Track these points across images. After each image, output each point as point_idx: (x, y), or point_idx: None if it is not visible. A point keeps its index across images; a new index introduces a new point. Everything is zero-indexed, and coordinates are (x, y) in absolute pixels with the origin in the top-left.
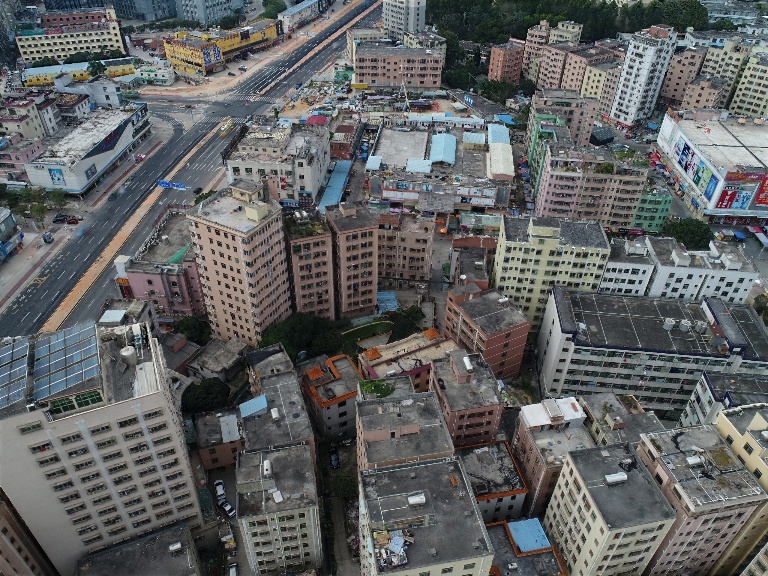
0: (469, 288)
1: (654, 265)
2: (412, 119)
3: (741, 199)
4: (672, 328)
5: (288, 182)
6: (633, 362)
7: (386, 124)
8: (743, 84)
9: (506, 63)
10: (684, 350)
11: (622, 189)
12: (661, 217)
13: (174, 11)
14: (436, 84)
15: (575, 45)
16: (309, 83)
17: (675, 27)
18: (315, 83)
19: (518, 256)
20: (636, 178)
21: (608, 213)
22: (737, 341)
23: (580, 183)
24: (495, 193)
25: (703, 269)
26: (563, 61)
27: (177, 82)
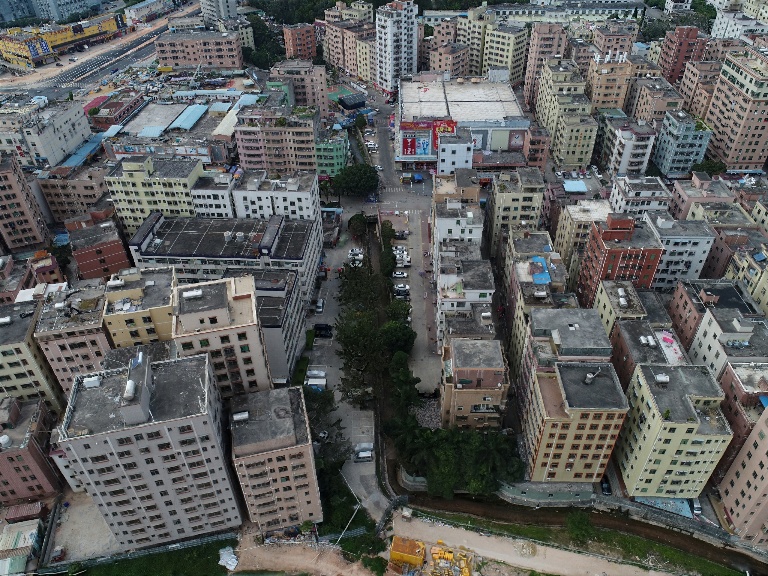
0: (82, 218)
1: (230, 191)
2: (177, 94)
3: (422, 146)
4: (231, 239)
5: (24, 150)
6: (192, 267)
7: (155, 99)
8: (487, 49)
9: (297, 42)
10: (228, 254)
11: (297, 140)
12: (339, 163)
13: (34, 11)
14: (235, 64)
15: (356, 22)
16: (126, 69)
17: (472, 2)
18: (132, 69)
19: (120, 189)
20: (304, 129)
21: (294, 162)
22: (265, 244)
23: (261, 136)
24: (208, 151)
25: (266, 191)
26: (342, 37)
27: (4, 74)
